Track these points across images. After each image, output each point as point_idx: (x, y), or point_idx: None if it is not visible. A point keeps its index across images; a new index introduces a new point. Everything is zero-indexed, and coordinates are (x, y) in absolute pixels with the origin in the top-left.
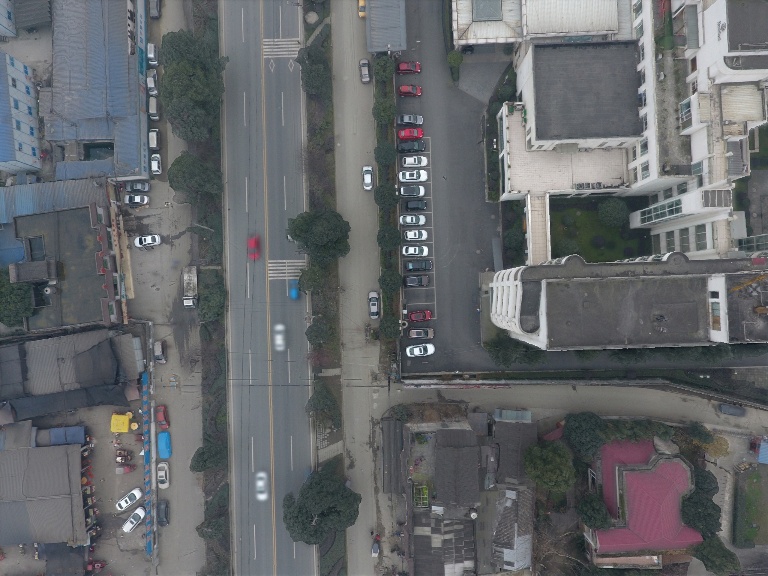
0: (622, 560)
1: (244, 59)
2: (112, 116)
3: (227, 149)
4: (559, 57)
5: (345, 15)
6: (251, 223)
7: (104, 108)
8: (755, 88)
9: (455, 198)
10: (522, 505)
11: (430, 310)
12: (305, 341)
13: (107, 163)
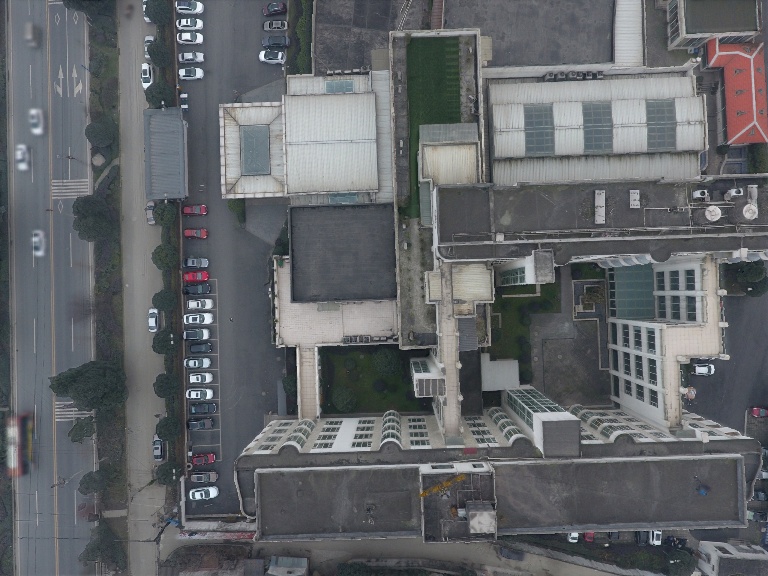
0: None
1: (33, 200)
2: None
3: (16, 290)
4: (318, 217)
5: (134, 155)
6: (39, 364)
7: None
8: (485, 267)
9: (241, 340)
10: None
11: (214, 452)
12: None
13: None
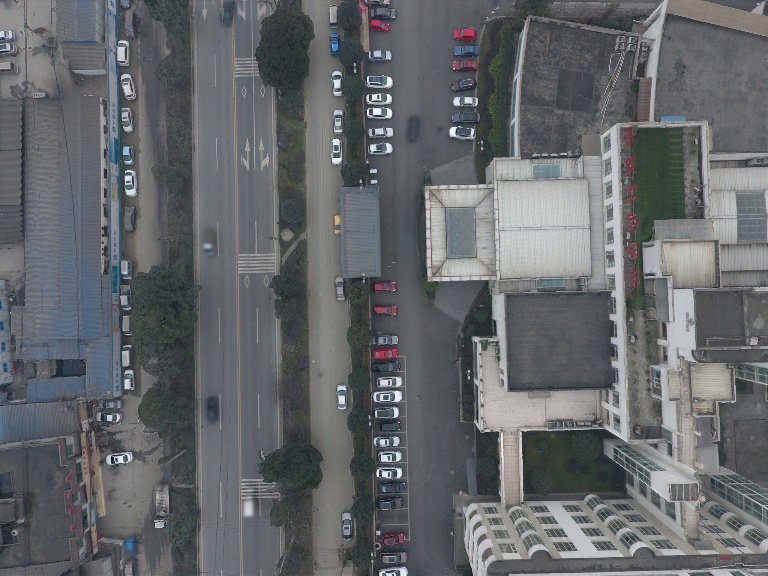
0: None
1: (219, 274)
2: (84, 339)
3: (201, 365)
4: (532, 304)
5: (321, 230)
6: (224, 441)
7: (76, 330)
8: (724, 366)
9: (430, 417)
10: None
11: (403, 532)
12: (277, 561)
13: (79, 385)
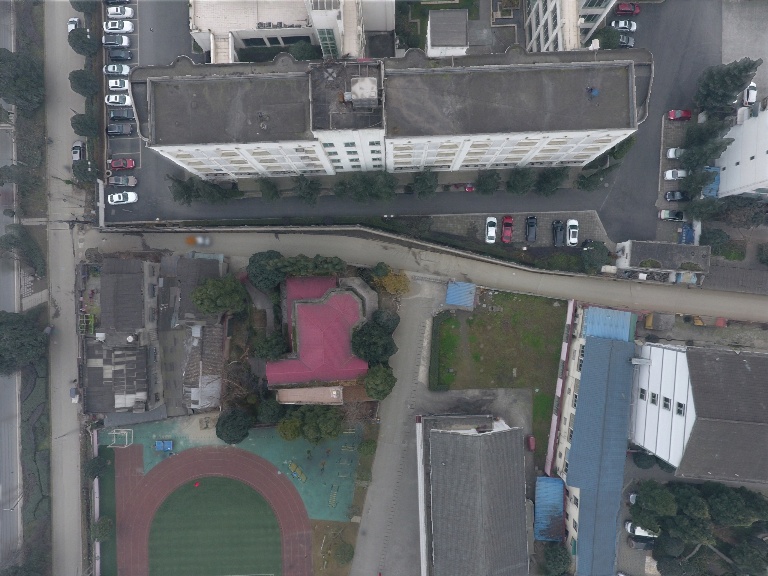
0: (307, 398)
1: None
2: None
3: None
4: None
5: None
6: None
7: None
8: None
9: (162, 50)
10: (208, 344)
11: (134, 159)
12: (11, 191)
13: None
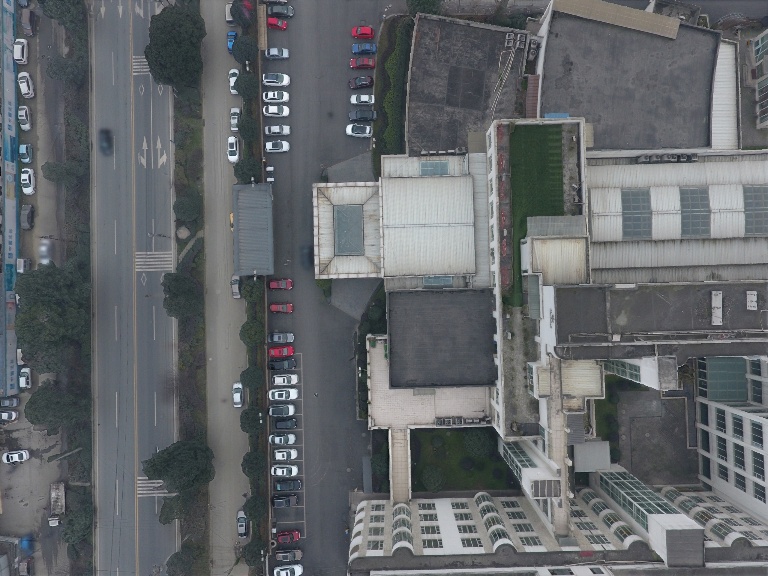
0: None
1: (116, 272)
2: None
3: (98, 363)
4: (416, 301)
5: (219, 228)
6: (121, 439)
7: None
8: (594, 362)
9: (326, 415)
10: None
11: (299, 530)
12: None
13: None
